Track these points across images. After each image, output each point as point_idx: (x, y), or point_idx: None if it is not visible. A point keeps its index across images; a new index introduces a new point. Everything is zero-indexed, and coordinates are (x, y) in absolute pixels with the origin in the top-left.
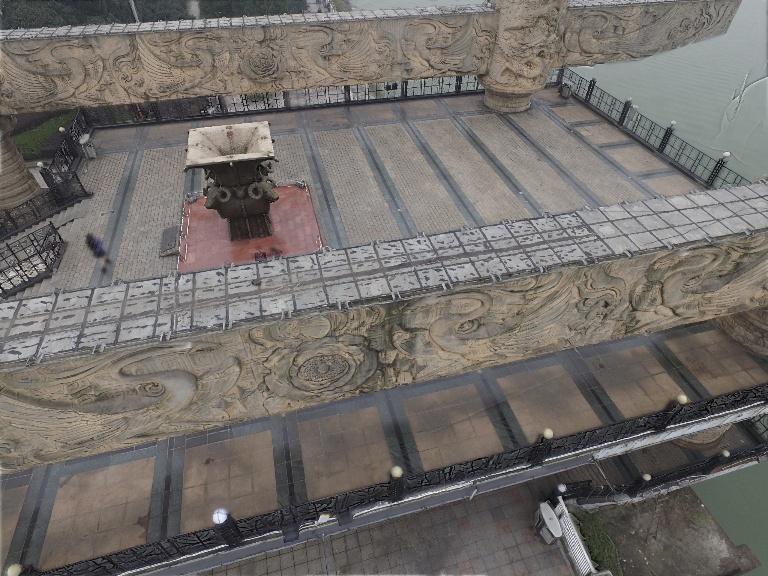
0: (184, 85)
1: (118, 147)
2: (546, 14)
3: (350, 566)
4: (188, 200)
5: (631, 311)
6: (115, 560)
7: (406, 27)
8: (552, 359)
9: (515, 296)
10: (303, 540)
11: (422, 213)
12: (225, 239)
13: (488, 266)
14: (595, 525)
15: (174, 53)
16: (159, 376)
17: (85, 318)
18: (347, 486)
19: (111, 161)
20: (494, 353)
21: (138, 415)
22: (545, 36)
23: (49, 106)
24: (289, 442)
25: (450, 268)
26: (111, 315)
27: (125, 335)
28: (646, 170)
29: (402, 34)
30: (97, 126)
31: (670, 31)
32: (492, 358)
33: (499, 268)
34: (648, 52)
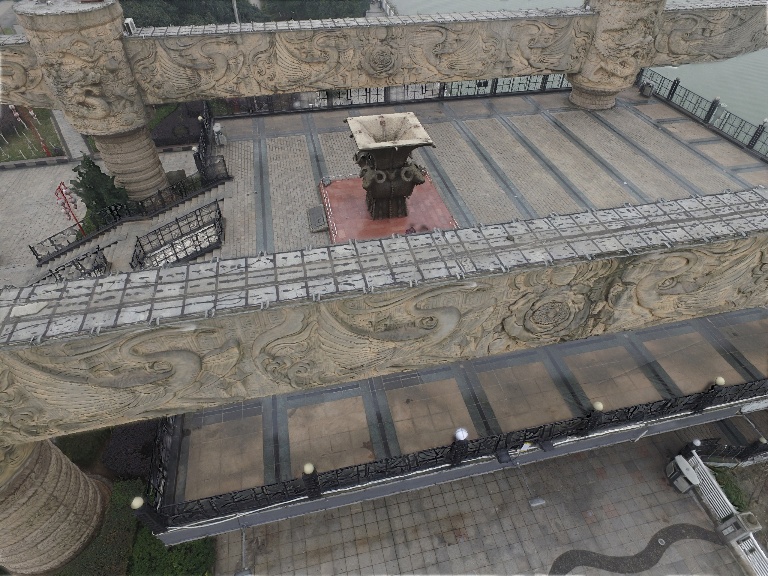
0: (309, 79)
1: (241, 136)
2: (646, 17)
3: (506, 505)
4: (324, 183)
5: None
6: (372, 468)
7: (513, 28)
8: (689, 327)
9: (713, 257)
10: (500, 467)
11: (538, 199)
12: (367, 218)
13: (697, 230)
14: None
15: (306, 50)
16: (439, 311)
17: (387, 261)
18: (534, 424)
19: (239, 148)
20: (675, 310)
21: (406, 346)
22: (642, 37)
23: (191, 97)
24: (473, 388)
25: (665, 231)
26: (407, 260)
27: (428, 274)
28: (739, 165)
29: (508, 34)
30: (217, 116)
31: (754, 34)
32: (672, 315)
33: (706, 232)
34: (731, 54)
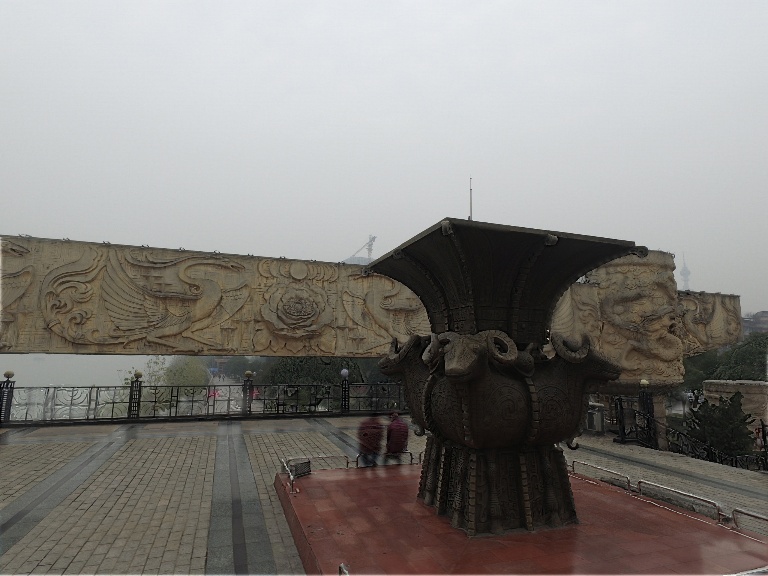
0: None
1: None
2: None
3: None
4: None
5: None
6: None
7: None
8: None
9: None
10: None
11: None
12: None
13: None
14: None
15: None
16: None
17: None
18: None
19: None
20: None
21: None
22: None
23: None
24: None
25: None
26: None
27: None
28: None
29: None
30: None
31: None
32: None
33: None
34: None
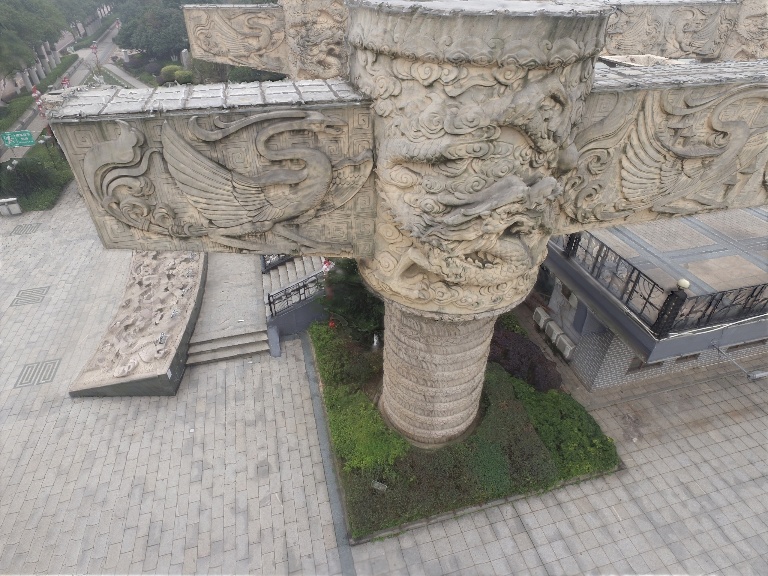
0: None
1: None
2: None
3: None
4: None
5: None
6: None
7: (673, 13)
8: None
9: None
10: None
11: None
12: None
13: None
14: None
15: None
16: None
17: None
18: None
19: None
20: None
21: None
22: None
23: None
24: None
25: None
26: None
27: None
28: None
29: (669, 18)
30: None
31: None
32: None
33: None
34: None
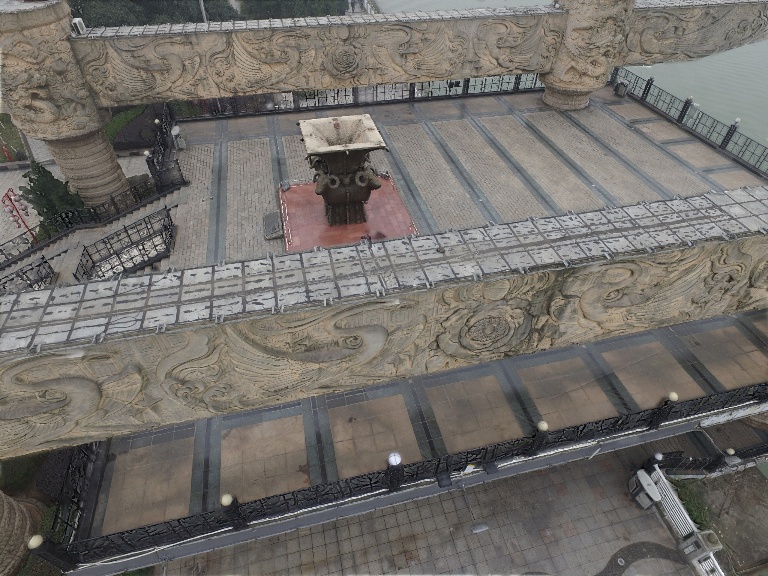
0: (270, 80)
1: (203, 139)
2: (615, 15)
3: (462, 524)
4: (282, 188)
5: (747, 287)
6: (300, 496)
7: (480, 27)
8: (650, 337)
9: (659, 268)
10: (445, 490)
11: (503, 203)
12: (324, 224)
13: (640, 240)
14: (690, 492)
15: (265, 50)
16: (363, 330)
17: (304, 277)
18: (481, 443)
19: (199, 152)
20: (625, 323)
21: (332, 366)
22: (612, 36)
23: (146, 99)
24: (421, 405)
25: (607, 241)
26: (326, 275)
27: (345, 291)
28: (711, 165)
29: (475, 33)
30: (179, 119)
31: (728, 32)
32: (622, 327)
33: (651, 242)
34: (705, 52)
